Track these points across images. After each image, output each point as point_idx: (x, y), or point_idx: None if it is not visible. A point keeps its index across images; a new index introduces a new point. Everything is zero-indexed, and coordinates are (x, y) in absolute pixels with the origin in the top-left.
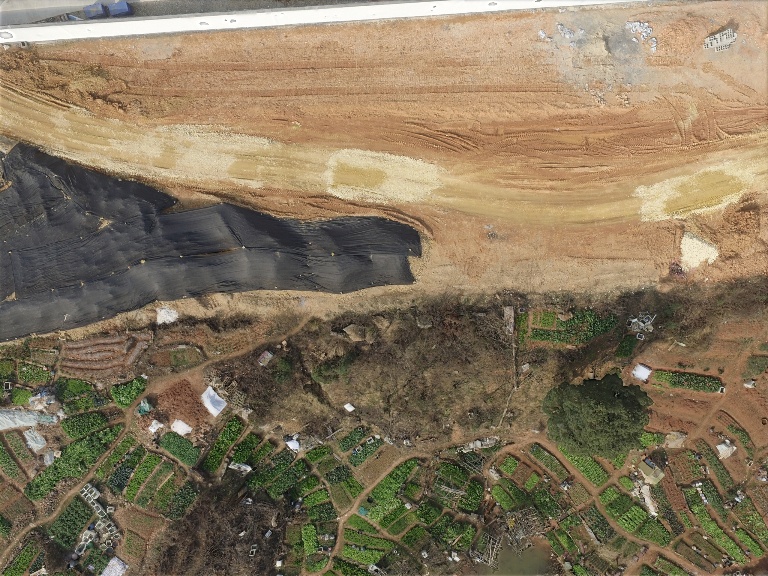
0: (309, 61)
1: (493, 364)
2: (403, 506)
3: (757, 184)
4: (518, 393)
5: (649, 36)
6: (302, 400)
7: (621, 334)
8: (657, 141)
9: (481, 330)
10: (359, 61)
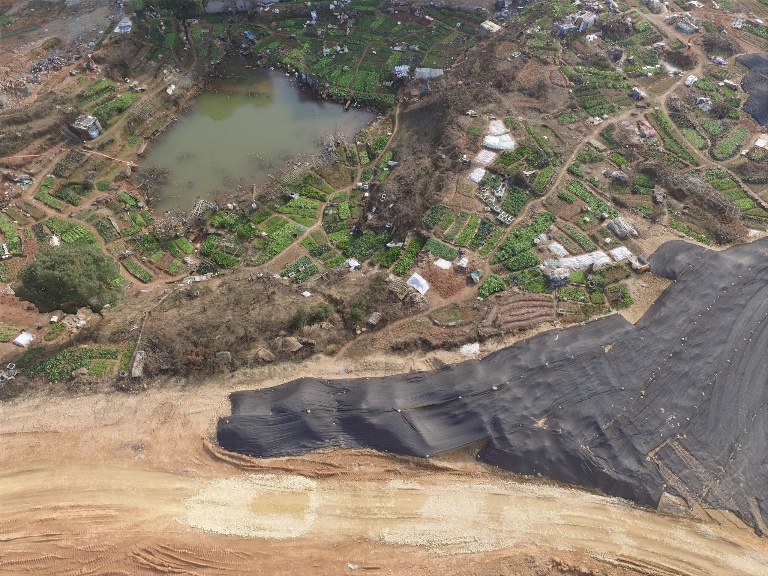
0: None
1: None
2: (268, 234)
3: None
4: None
5: None
6: (345, 293)
7: None
8: None
9: (168, 352)
10: None
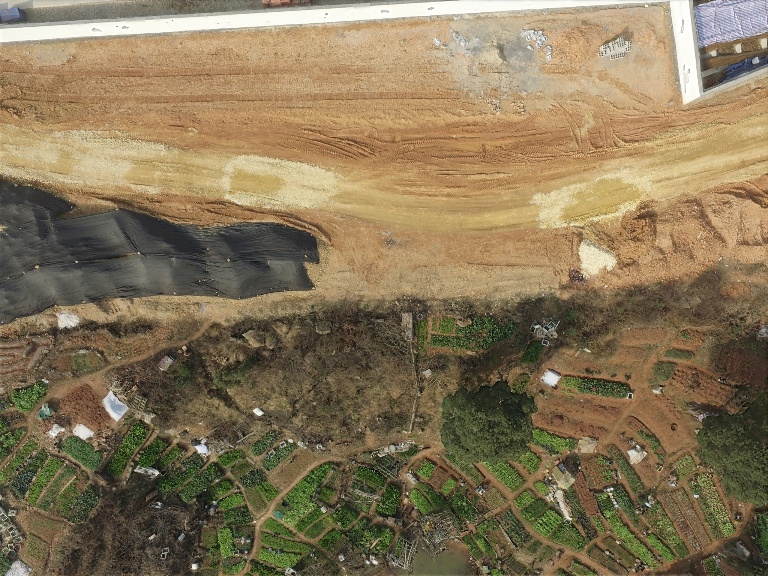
0: (204, 68)
1: (395, 370)
2: (319, 510)
3: (654, 192)
4: (425, 398)
5: (544, 44)
6: (207, 405)
7: (523, 340)
8: (554, 149)
9: (379, 336)
10: (254, 68)
